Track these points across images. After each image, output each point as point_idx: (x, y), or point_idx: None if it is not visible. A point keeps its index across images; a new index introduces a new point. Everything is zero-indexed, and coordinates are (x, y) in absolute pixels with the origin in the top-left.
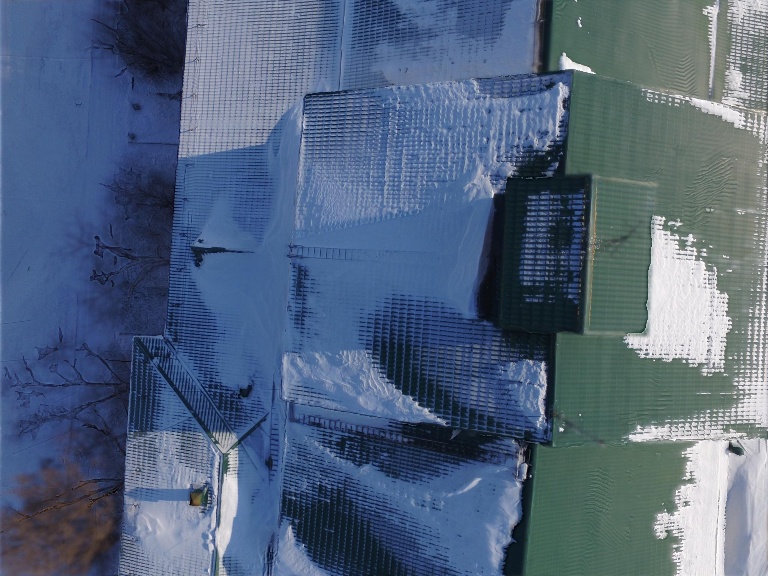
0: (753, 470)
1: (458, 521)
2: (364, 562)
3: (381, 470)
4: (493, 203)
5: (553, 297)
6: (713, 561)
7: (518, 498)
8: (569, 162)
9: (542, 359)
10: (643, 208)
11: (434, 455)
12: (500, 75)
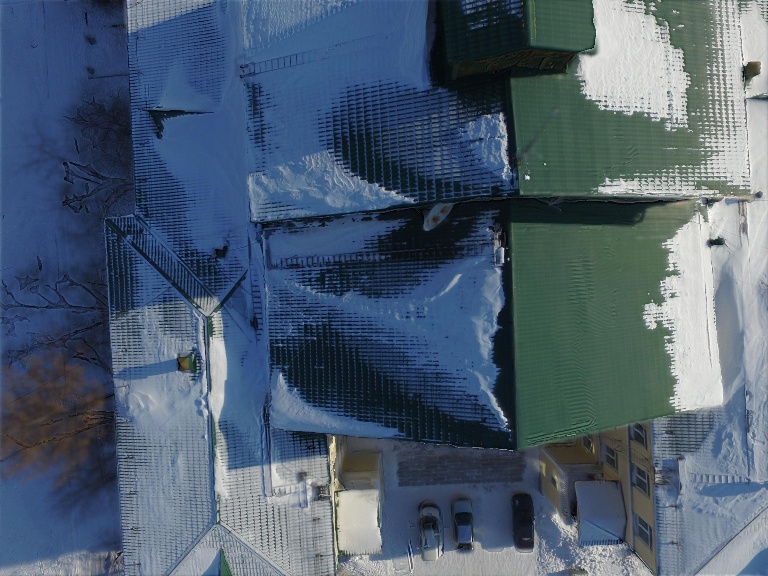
0: (738, 265)
1: (443, 322)
2: (356, 389)
3: (362, 294)
4: None
5: (497, 17)
6: (707, 353)
7: (499, 284)
8: None
9: (500, 111)
10: None
11: (412, 265)
12: None
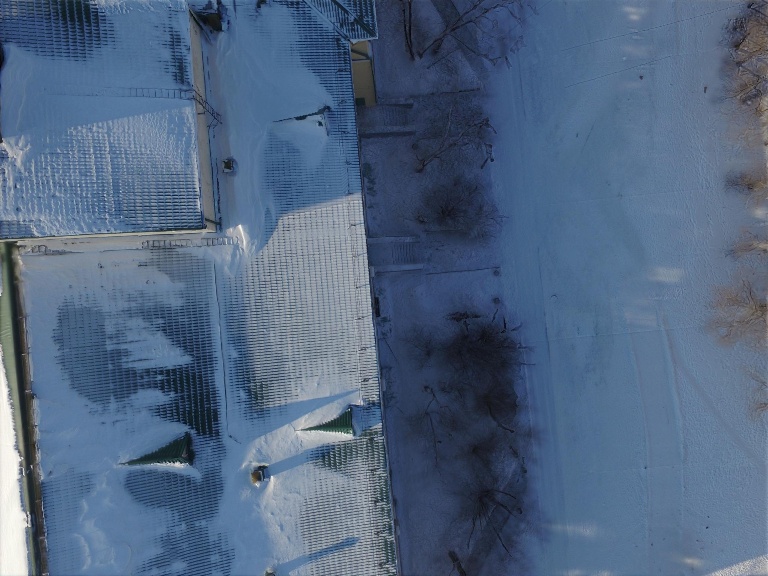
0: None
1: None
2: None
3: None
4: (2, 135)
5: None
6: None
7: None
8: None
9: None
10: None
11: None
12: (53, 274)
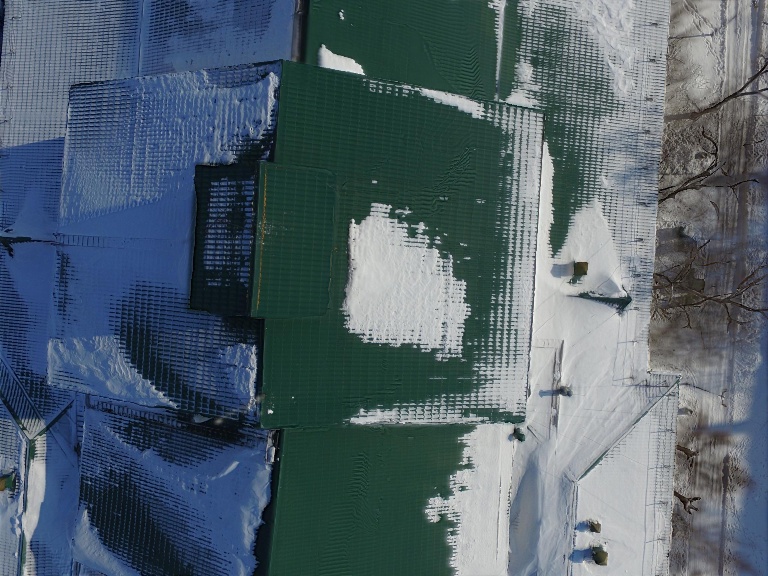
0: (544, 456)
1: (219, 504)
2: (144, 545)
3: (160, 455)
4: None
5: (229, 281)
6: (495, 545)
7: (267, 481)
8: (279, 150)
9: (254, 343)
10: (322, 194)
11: (203, 439)
12: None
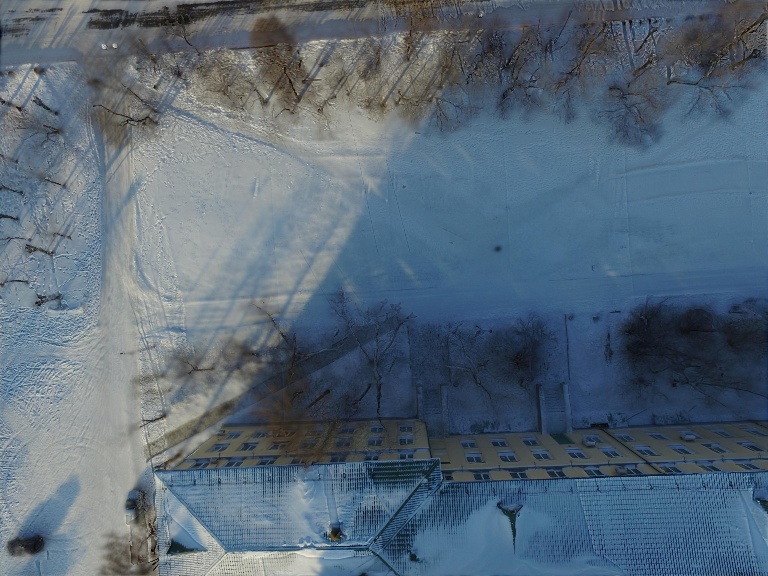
0: None
1: None
2: None
3: None
4: None
5: None
6: None
7: None
8: None
9: None
10: None
11: None
12: None
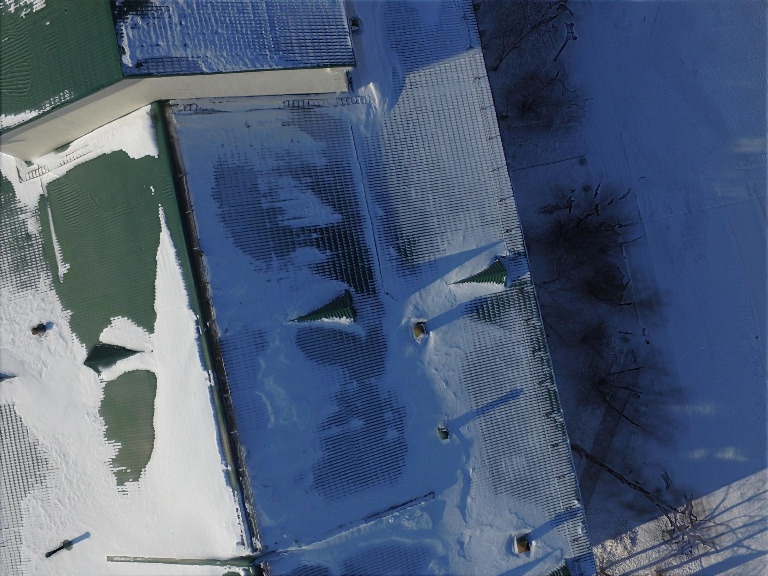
0: None
1: None
2: None
3: None
4: None
5: None
6: None
7: None
8: (108, 7)
9: None
10: None
11: None
12: (205, 133)
